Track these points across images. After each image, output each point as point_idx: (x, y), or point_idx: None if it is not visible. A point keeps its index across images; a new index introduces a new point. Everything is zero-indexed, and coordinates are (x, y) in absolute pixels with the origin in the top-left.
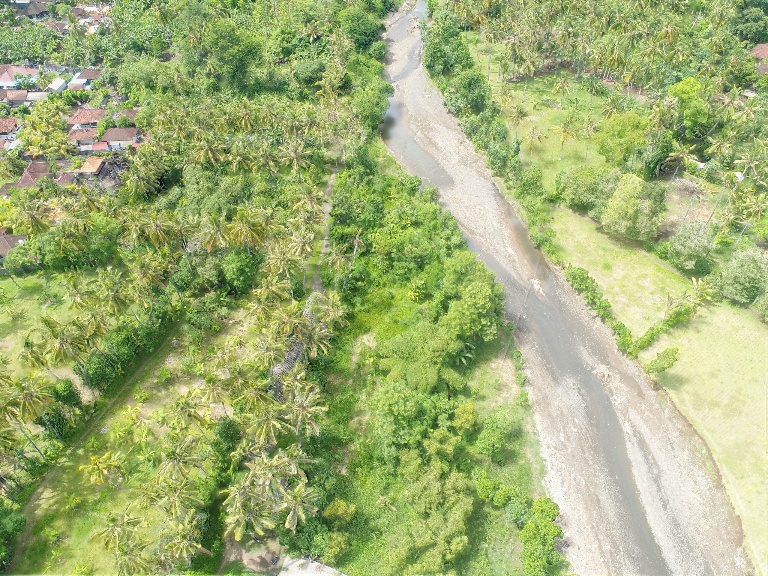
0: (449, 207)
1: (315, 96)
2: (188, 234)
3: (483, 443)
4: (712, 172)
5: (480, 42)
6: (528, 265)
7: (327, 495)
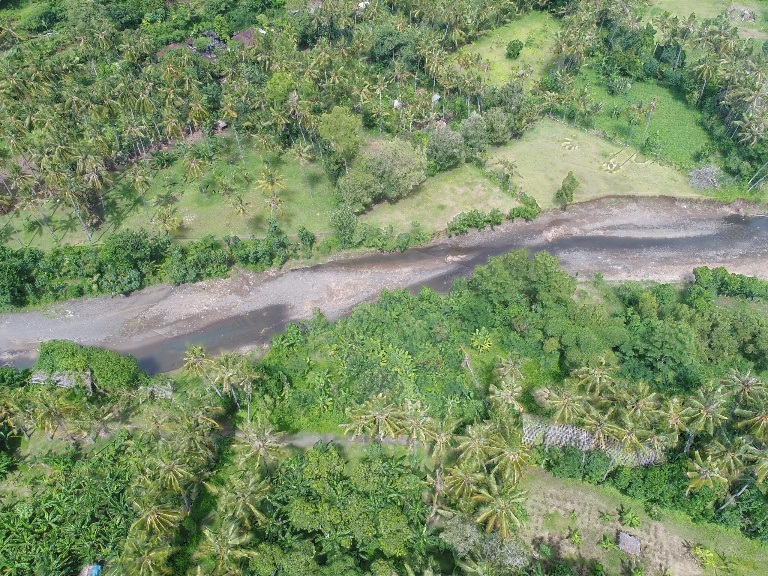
0: (327, 312)
1: (4, 459)
2: None
3: (671, 295)
4: None
5: None
6: (427, 260)
7: None
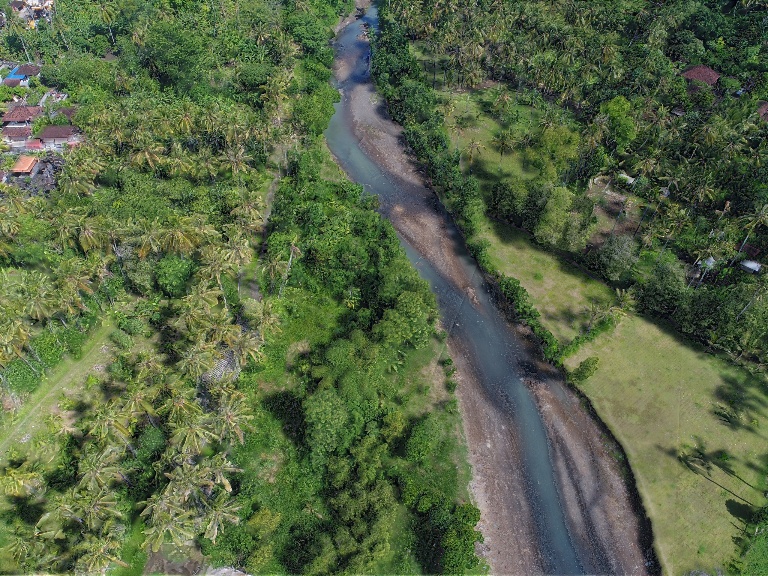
0: (390, 214)
1: (260, 99)
2: (119, 238)
3: (409, 450)
4: (641, 187)
5: (427, 51)
6: (464, 274)
7: (253, 503)
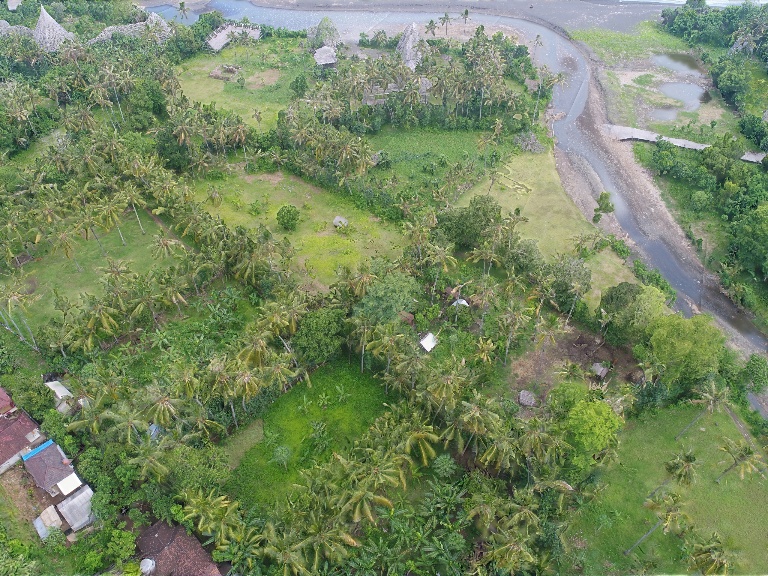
0: None
1: None
2: None
3: None
4: None
5: None
6: None
7: None
